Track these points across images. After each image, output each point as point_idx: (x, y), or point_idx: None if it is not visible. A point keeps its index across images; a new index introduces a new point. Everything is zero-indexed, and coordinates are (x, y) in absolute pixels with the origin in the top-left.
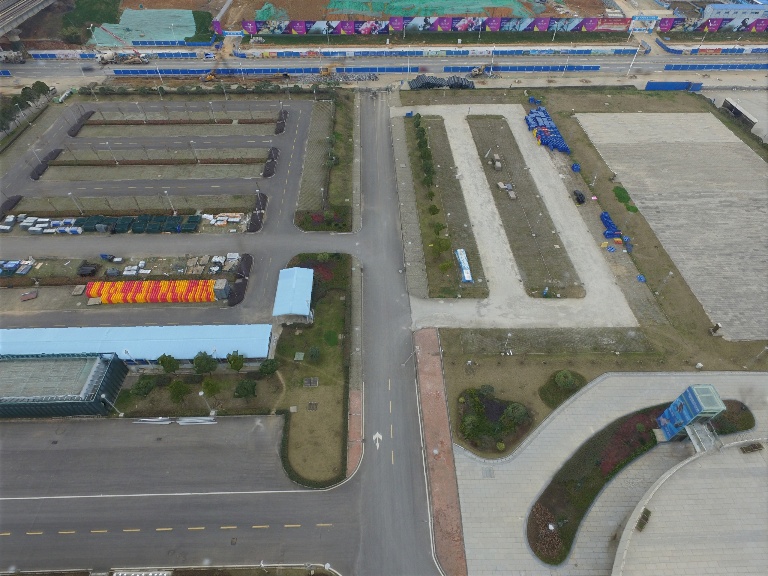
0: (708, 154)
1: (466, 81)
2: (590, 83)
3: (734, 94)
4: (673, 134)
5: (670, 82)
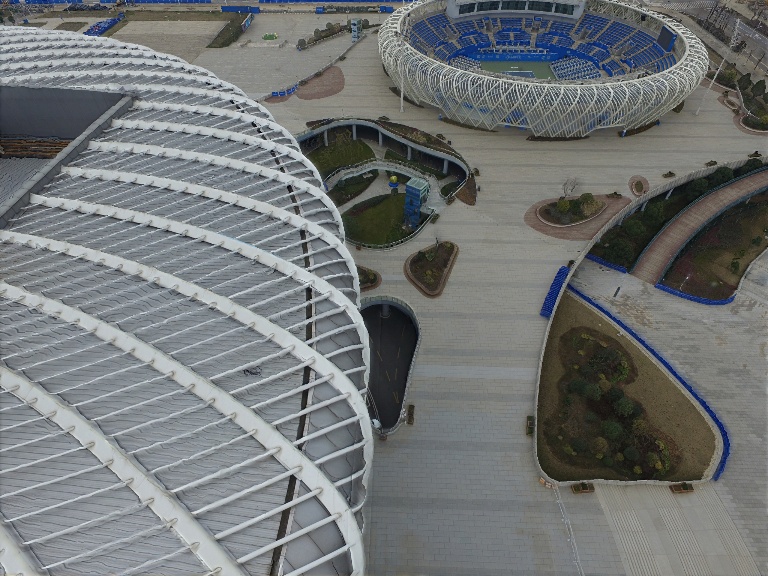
0: (178, 39)
1: (101, 7)
2: (192, 9)
3: (281, 15)
4: (176, 30)
5: (236, 6)
